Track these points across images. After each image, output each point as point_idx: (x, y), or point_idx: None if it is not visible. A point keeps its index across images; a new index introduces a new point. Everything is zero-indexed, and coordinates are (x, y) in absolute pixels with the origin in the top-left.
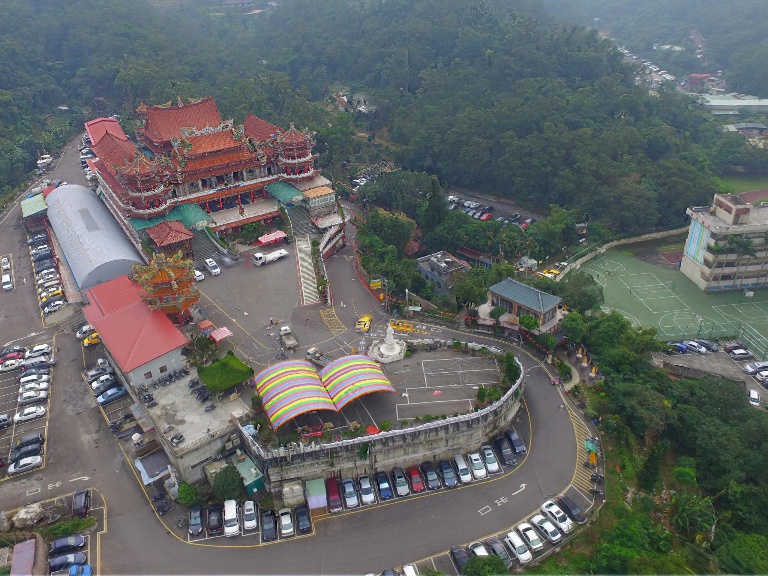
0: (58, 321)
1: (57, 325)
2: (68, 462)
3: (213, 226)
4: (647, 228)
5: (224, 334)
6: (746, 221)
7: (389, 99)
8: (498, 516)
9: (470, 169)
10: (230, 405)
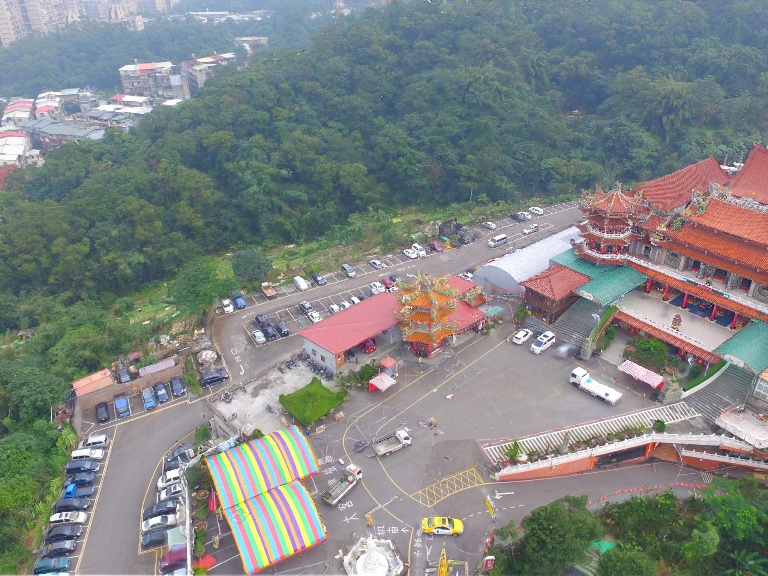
0: None
1: None
2: (261, 357)
3: (626, 312)
4: None
5: (379, 382)
6: None
7: None
8: None
9: None
10: (275, 422)
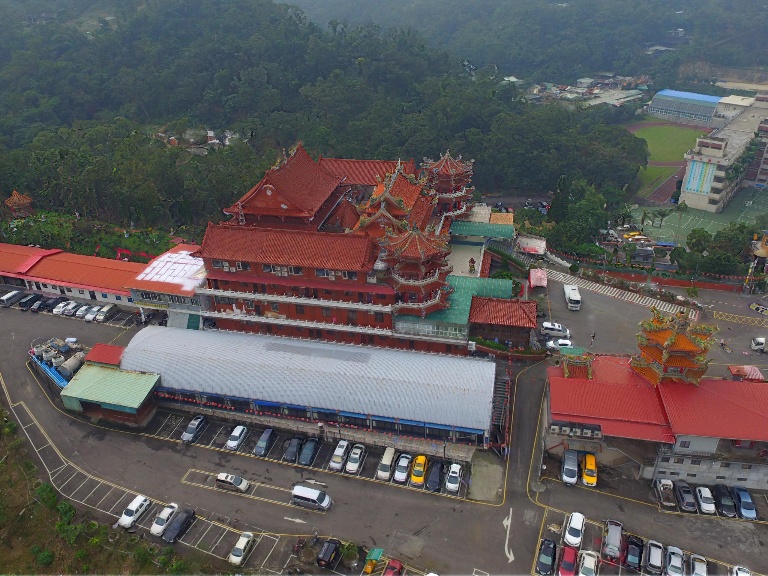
0: (499, 488)
1: (510, 492)
2: None
3: None
4: None
5: (757, 370)
6: (725, 153)
7: (289, 124)
8: None
9: None
10: None
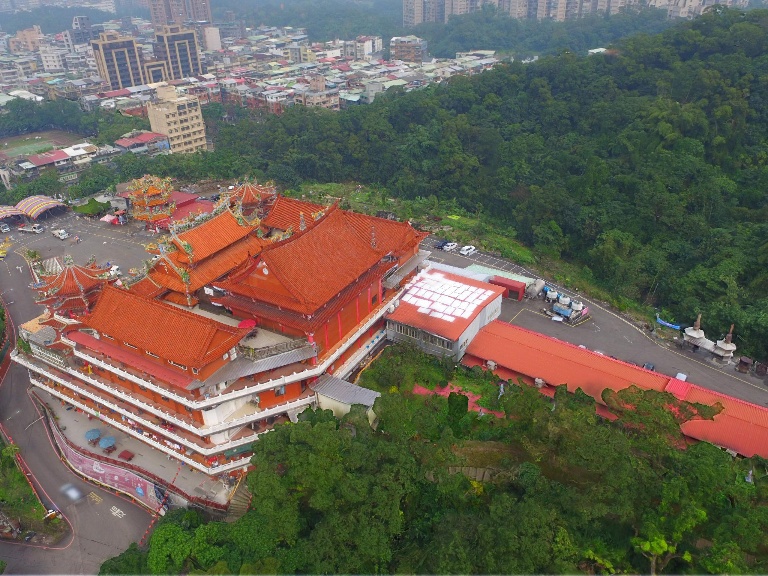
0: None
1: None
2: None
3: None
4: None
5: None
6: None
7: None
8: None
9: None
10: None
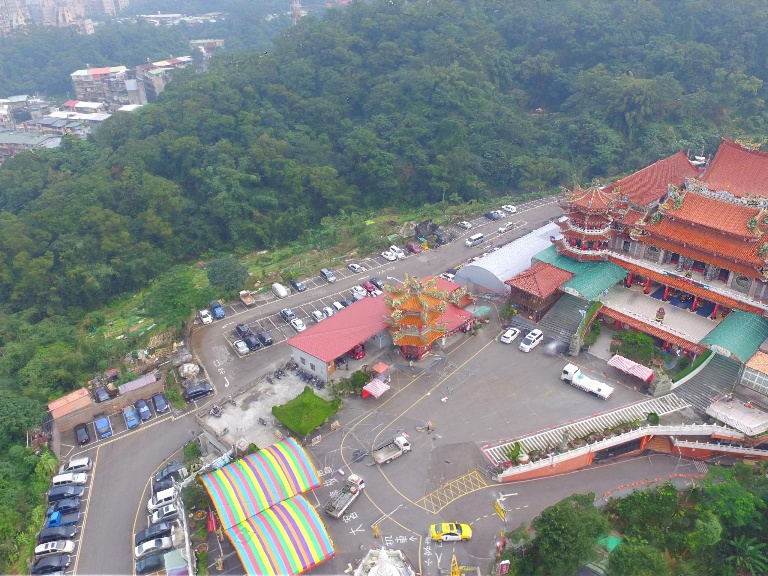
0: None
1: None
2: (245, 367)
3: (610, 306)
4: None
5: (373, 389)
6: None
7: None
8: None
9: None
10: (269, 435)
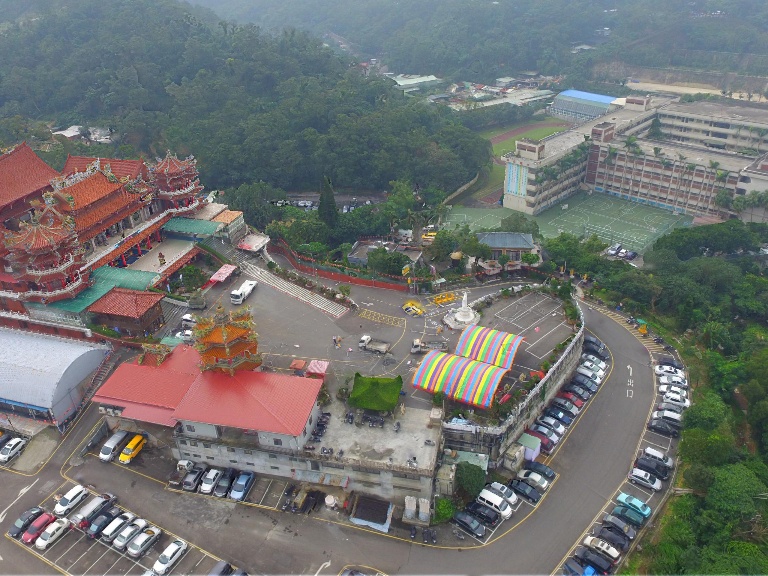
0: (42, 460)
1: (48, 465)
2: (287, 565)
3: None
4: (458, 183)
5: (324, 365)
6: (544, 155)
7: (144, 122)
8: (641, 392)
9: (286, 171)
10: (408, 417)
